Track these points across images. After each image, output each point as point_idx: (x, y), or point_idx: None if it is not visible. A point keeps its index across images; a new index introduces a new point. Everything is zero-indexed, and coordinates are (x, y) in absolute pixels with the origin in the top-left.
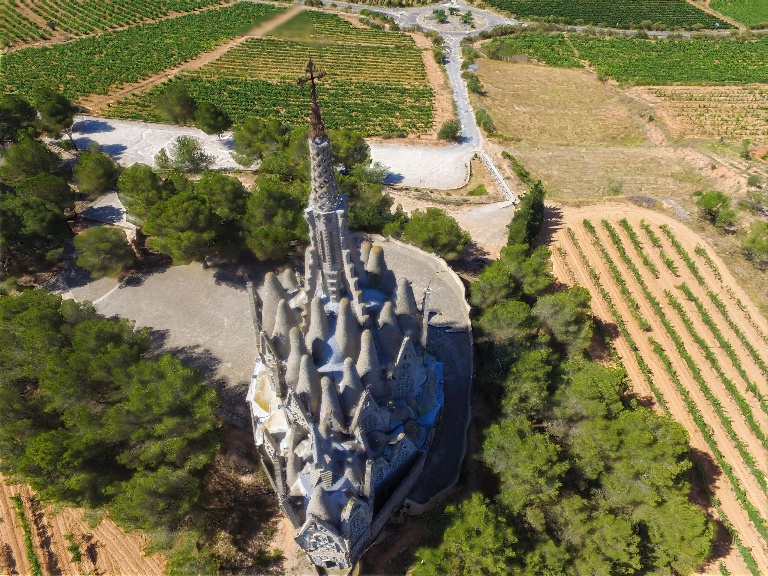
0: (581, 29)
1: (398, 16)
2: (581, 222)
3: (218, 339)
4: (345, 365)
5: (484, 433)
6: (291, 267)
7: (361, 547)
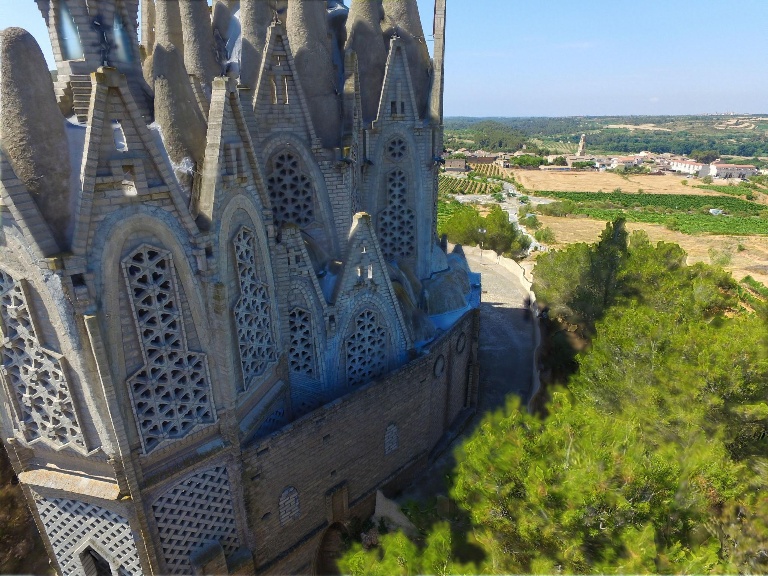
0: (639, 208)
1: (459, 198)
2: None
3: None
4: None
5: (570, 382)
6: None
7: (209, 546)
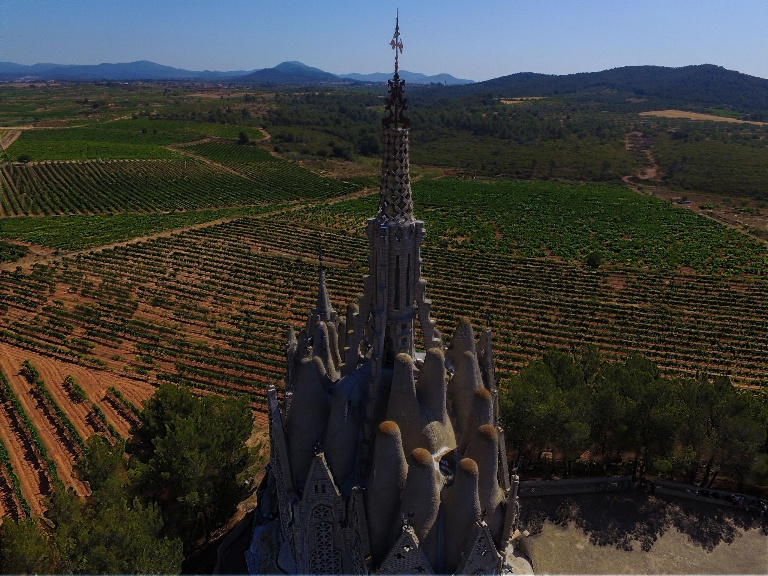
0: None
1: None
2: None
3: (641, 573)
4: None
5: None
6: None
7: None
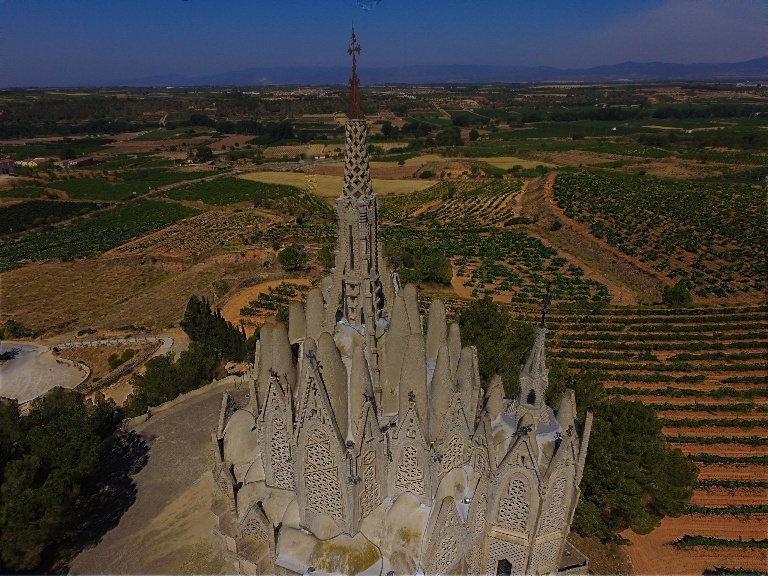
0: None
1: None
2: (237, 315)
3: None
4: (458, 330)
5: None
6: (73, 544)
7: None
